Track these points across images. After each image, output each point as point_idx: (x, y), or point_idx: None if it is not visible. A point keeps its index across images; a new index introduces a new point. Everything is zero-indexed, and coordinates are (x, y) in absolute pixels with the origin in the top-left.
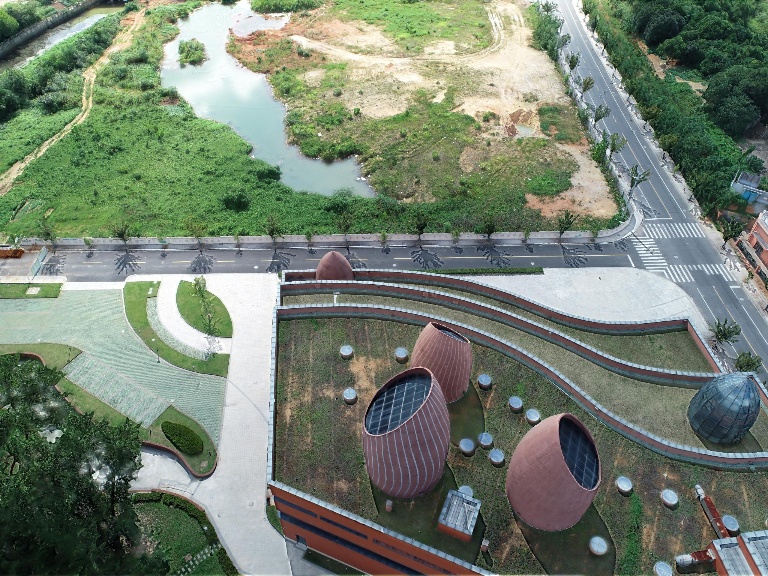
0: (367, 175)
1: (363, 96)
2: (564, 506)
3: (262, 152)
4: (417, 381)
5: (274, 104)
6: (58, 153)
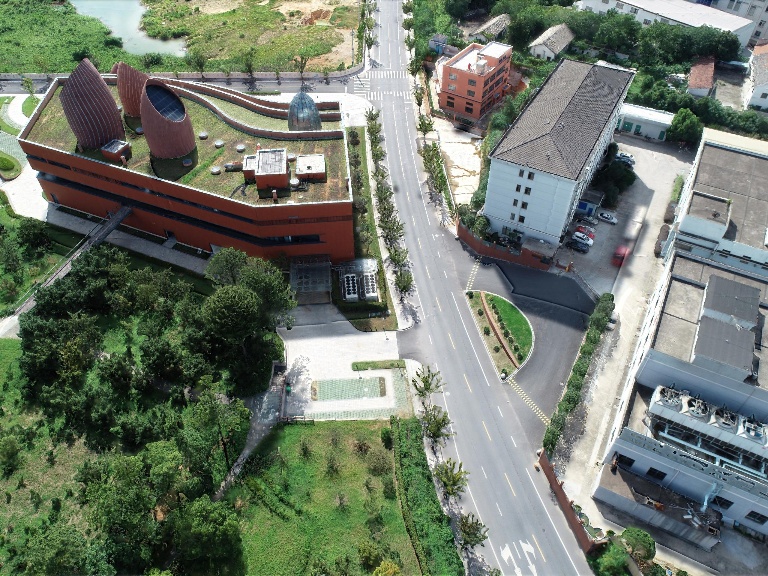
0: (188, 47)
1: (207, 1)
2: (157, 130)
3: (118, 34)
4: None
5: (139, 7)
6: None
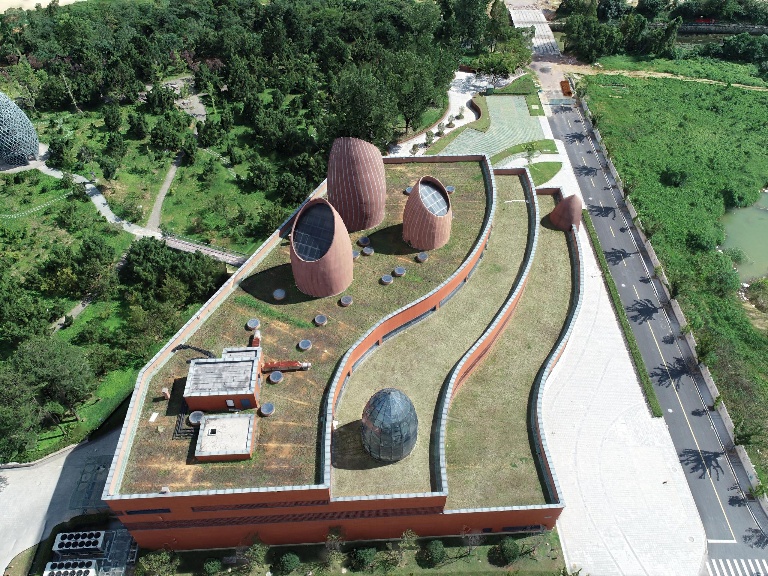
0: None
1: None
2: None
3: None
4: None
5: None
6: (693, 86)
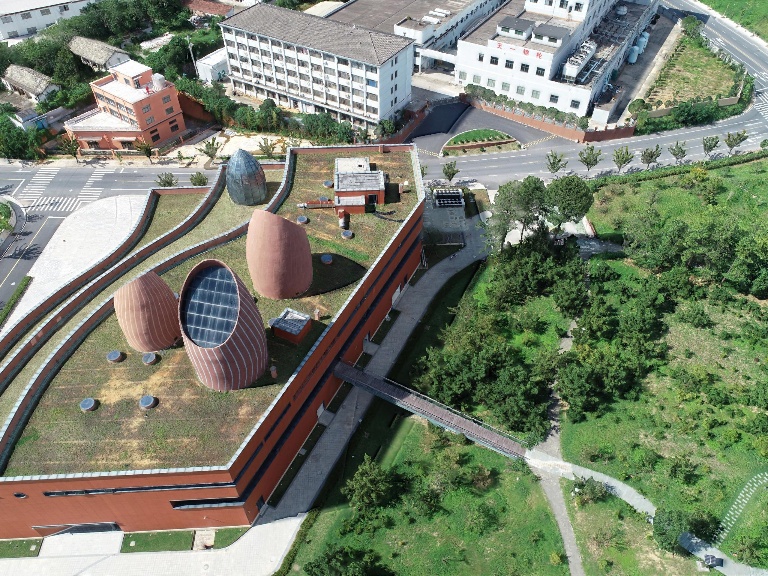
0: None
1: None
2: (308, 249)
3: None
4: (195, 287)
5: None
6: None
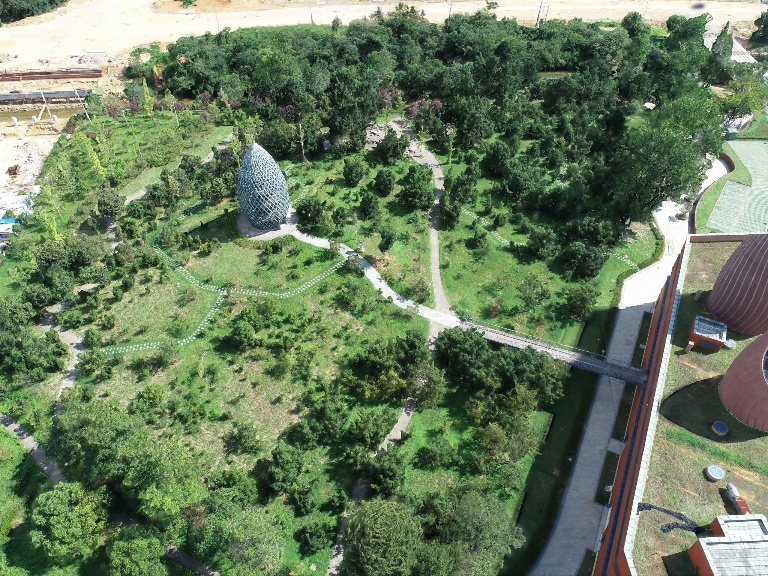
0: None
1: None
2: (742, 367)
3: None
4: None
5: None
6: None
